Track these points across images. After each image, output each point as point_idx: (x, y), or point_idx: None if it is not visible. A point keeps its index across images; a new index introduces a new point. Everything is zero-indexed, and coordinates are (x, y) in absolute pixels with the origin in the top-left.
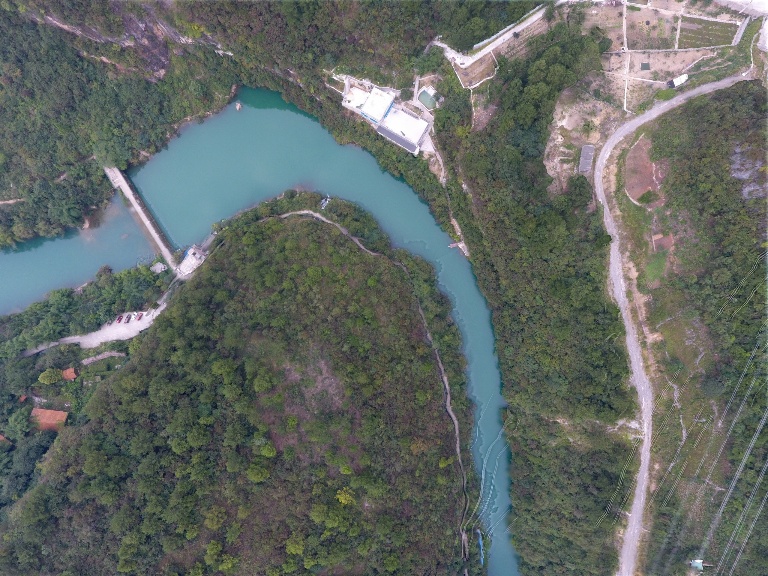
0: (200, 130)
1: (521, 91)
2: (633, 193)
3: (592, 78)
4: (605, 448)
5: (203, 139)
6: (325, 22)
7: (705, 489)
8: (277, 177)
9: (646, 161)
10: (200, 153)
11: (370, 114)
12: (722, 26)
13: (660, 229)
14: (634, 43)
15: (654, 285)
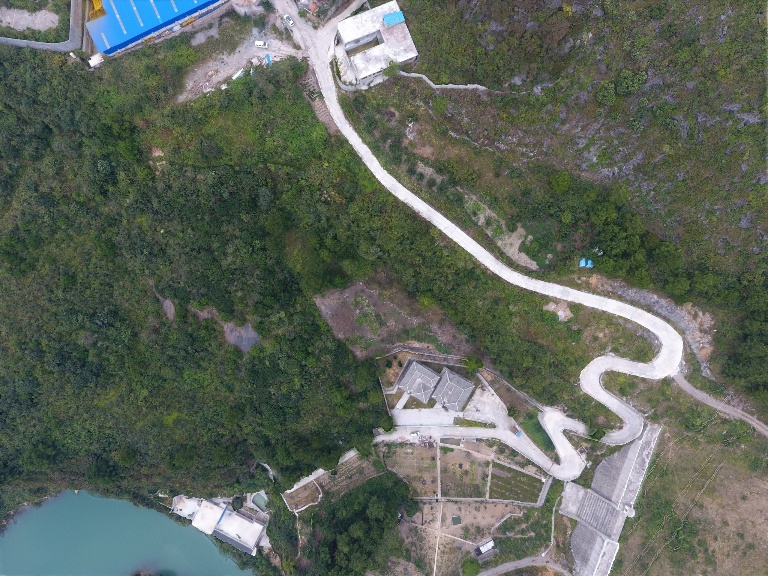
0: (37, 517)
1: (328, 568)
2: None
3: (405, 534)
4: None
5: (40, 527)
6: (133, 484)
7: None
8: (119, 564)
9: None
10: (38, 542)
11: (200, 528)
12: (529, 479)
13: None
14: (447, 490)
15: None
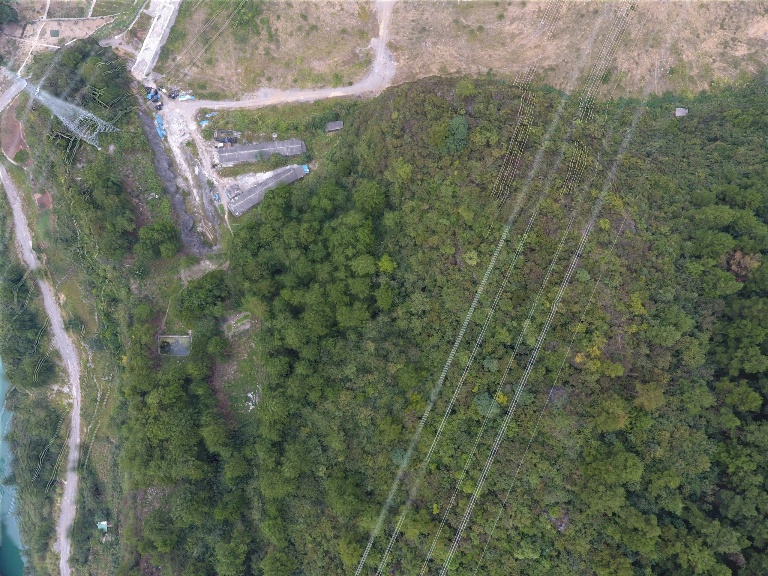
0: None
1: None
2: (9, 153)
3: (1, 45)
4: (44, 415)
5: None
6: None
7: (109, 448)
8: None
9: (15, 120)
10: None
11: None
12: None
13: (38, 187)
14: (53, 12)
15: (46, 244)
